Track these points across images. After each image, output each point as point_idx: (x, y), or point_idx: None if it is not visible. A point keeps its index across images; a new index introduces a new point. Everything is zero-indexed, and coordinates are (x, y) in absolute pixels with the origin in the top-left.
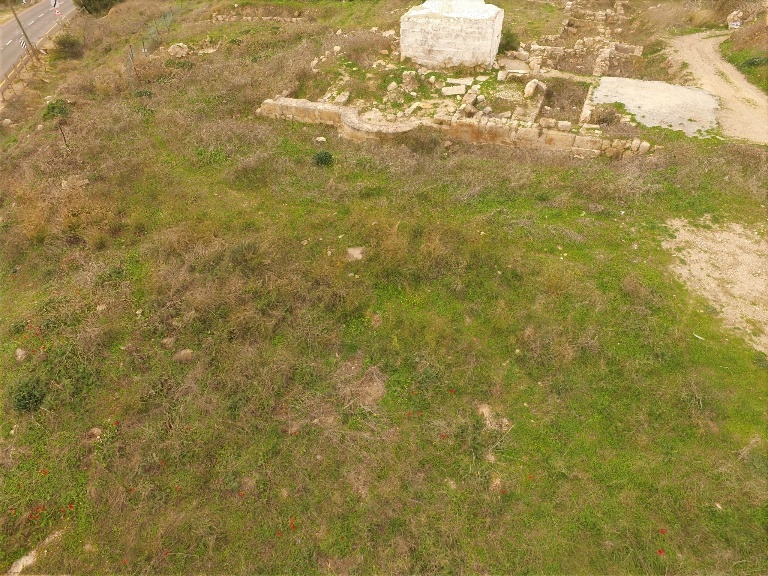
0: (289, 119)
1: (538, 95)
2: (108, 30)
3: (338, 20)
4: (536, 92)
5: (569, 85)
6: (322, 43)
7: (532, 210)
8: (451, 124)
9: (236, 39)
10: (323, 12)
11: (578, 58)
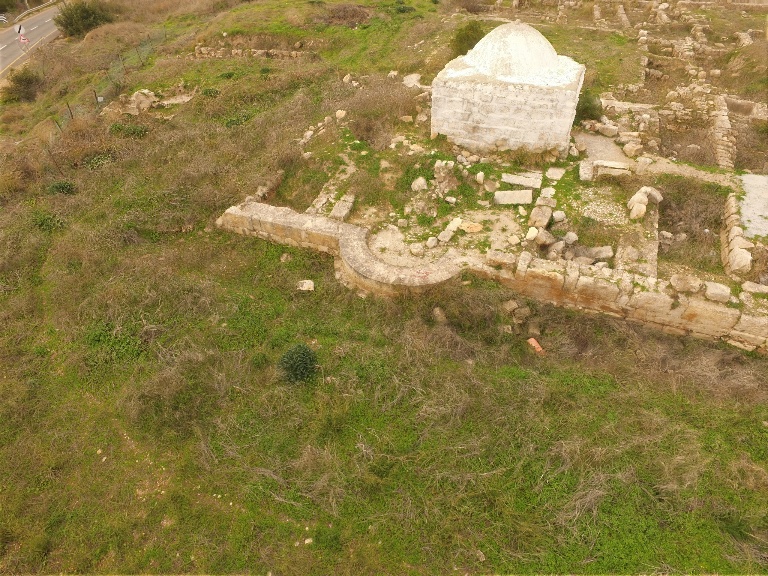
0: (263, 237)
1: (651, 213)
2: (72, 64)
3: (347, 57)
4: (646, 205)
5: (696, 192)
6: (323, 97)
7: (724, 571)
8: (516, 273)
9: (212, 89)
10: (330, 43)
11: (680, 124)
